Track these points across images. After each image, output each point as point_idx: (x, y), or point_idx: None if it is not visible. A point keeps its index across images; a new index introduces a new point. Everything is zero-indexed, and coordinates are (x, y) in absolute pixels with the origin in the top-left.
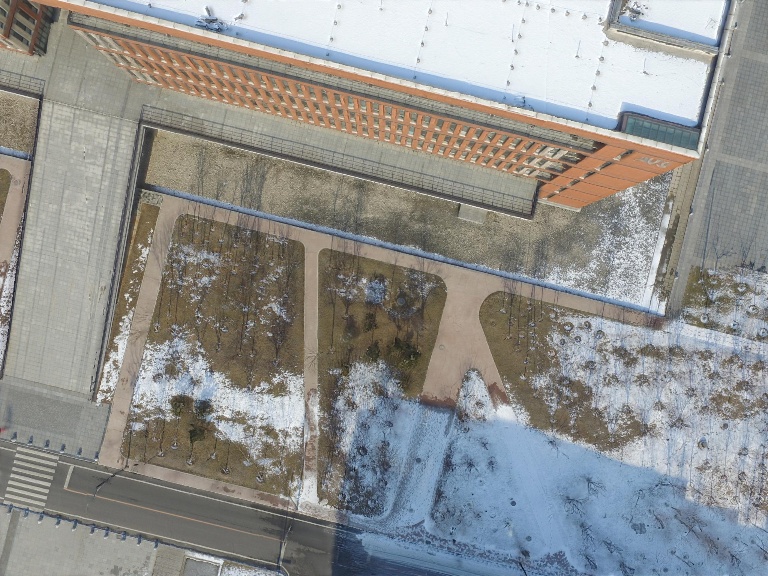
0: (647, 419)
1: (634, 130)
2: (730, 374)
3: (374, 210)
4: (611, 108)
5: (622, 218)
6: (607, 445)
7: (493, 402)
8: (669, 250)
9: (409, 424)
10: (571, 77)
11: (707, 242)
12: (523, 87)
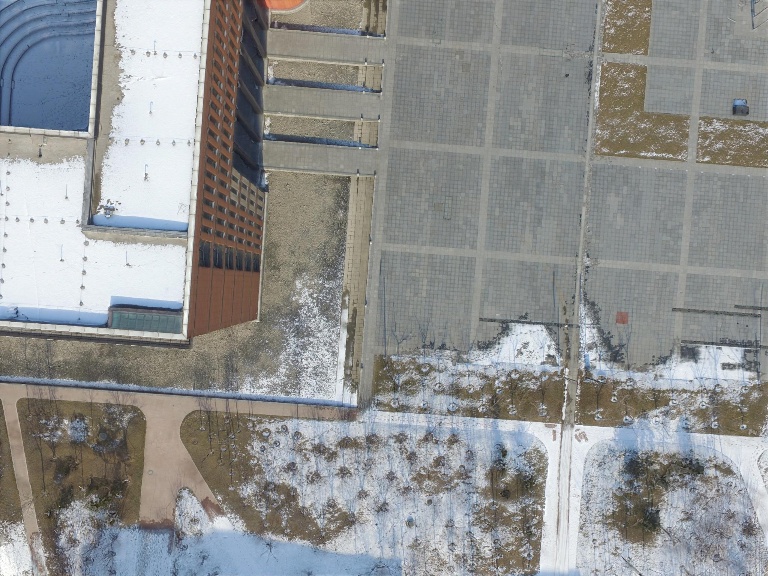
0: (353, 508)
1: (120, 324)
2: (426, 452)
3: (64, 353)
4: (101, 304)
5: (303, 320)
6: (320, 539)
7: (209, 515)
8: (352, 343)
9: (132, 550)
10: (59, 281)
11: (385, 330)
12: (16, 298)
